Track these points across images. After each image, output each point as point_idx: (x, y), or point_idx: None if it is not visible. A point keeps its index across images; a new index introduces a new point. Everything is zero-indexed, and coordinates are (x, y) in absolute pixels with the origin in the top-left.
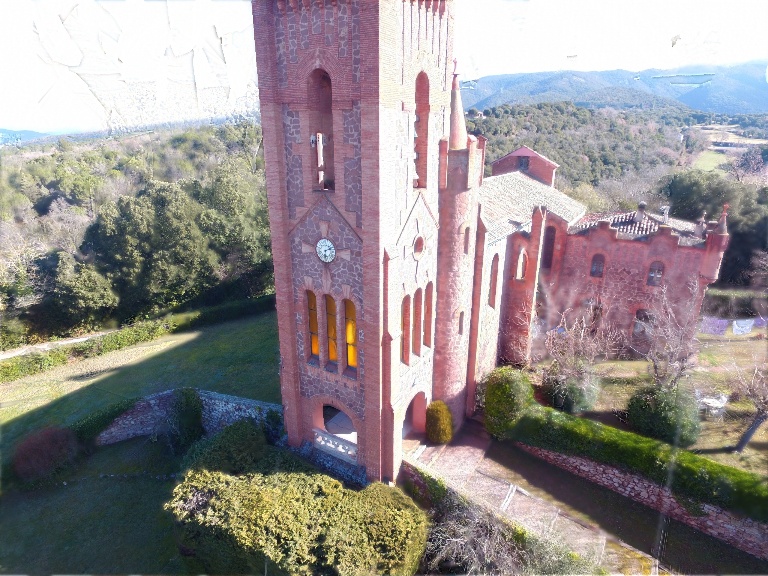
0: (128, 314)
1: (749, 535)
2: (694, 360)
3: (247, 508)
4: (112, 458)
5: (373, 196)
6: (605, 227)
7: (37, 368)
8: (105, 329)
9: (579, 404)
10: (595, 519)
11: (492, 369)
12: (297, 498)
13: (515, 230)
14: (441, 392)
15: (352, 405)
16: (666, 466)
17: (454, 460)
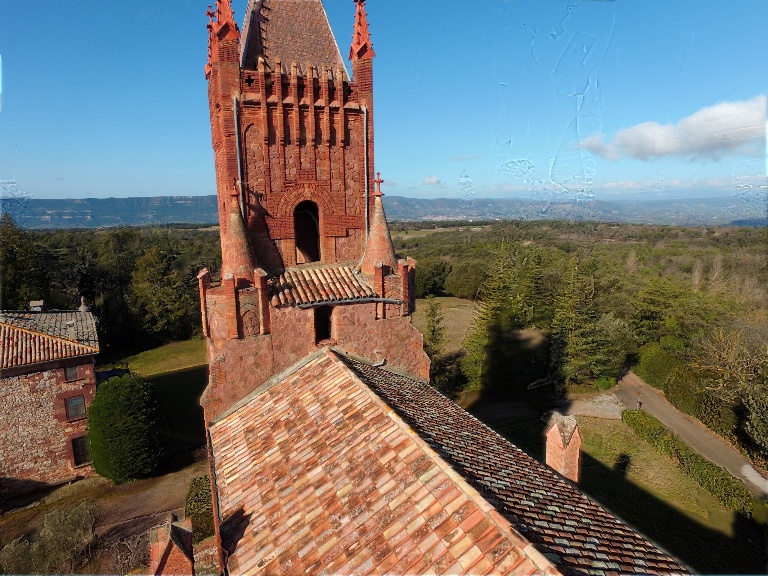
0: None
1: None
2: None
3: None
4: None
5: None
6: None
7: (655, 444)
8: None
9: None
10: None
11: None
12: None
13: None
14: None
15: None
16: None
17: None
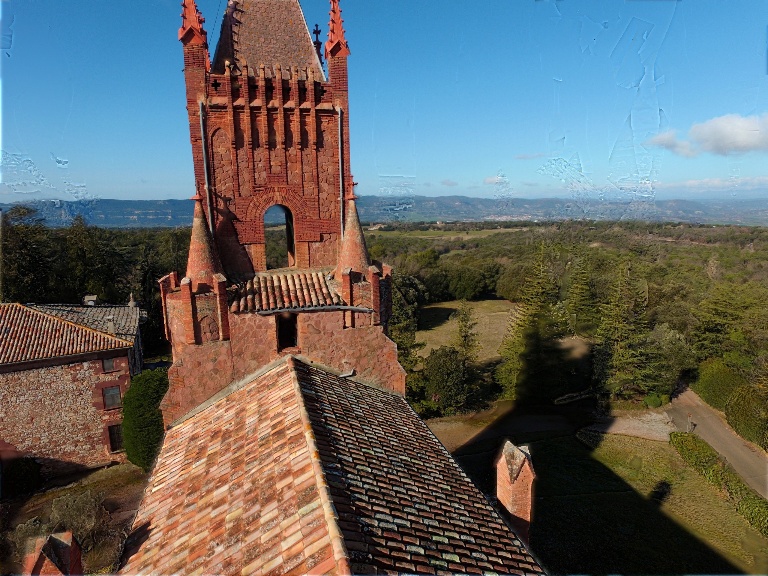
0: None
1: None
2: None
3: None
4: None
5: None
6: None
7: (703, 472)
8: None
9: None
10: None
11: None
12: None
13: None
14: None
15: None
16: None
17: None
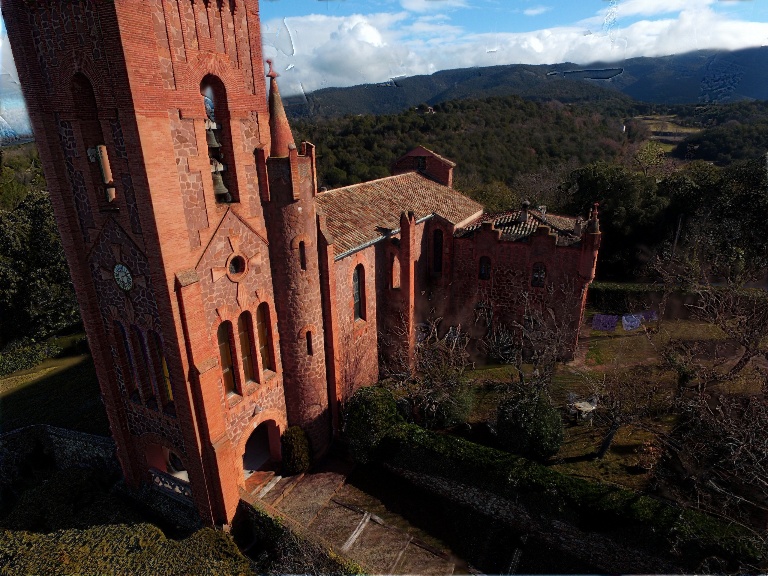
0: (10, 339)
1: (597, 549)
2: (581, 359)
3: (42, 574)
4: None
5: (149, 217)
6: (488, 229)
7: None
8: None
9: (450, 417)
10: (448, 544)
11: (374, 383)
12: (105, 556)
13: (381, 238)
14: (297, 417)
15: (178, 444)
16: (517, 483)
17: (309, 490)
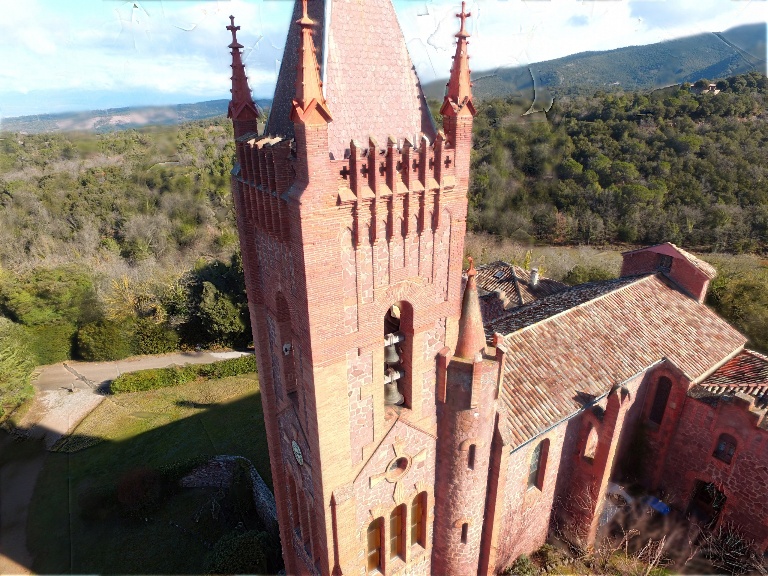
0: None
1: None
2: None
3: None
4: (184, 505)
5: (316, 445)
6: (742, 406)
7: (174, 382)
8: (235, 347)
9: None
10: None
11: (539, 545)
12: None
13: (579, 411)
14: None
15: None
16: None
17: None
